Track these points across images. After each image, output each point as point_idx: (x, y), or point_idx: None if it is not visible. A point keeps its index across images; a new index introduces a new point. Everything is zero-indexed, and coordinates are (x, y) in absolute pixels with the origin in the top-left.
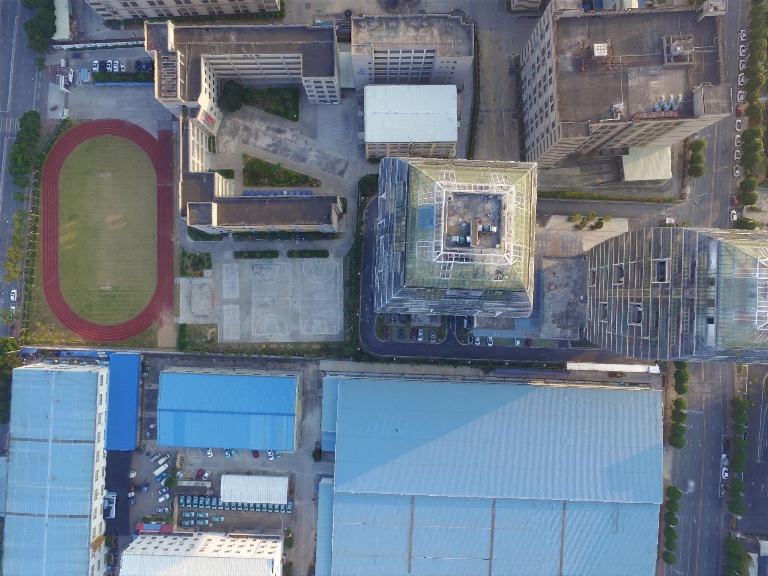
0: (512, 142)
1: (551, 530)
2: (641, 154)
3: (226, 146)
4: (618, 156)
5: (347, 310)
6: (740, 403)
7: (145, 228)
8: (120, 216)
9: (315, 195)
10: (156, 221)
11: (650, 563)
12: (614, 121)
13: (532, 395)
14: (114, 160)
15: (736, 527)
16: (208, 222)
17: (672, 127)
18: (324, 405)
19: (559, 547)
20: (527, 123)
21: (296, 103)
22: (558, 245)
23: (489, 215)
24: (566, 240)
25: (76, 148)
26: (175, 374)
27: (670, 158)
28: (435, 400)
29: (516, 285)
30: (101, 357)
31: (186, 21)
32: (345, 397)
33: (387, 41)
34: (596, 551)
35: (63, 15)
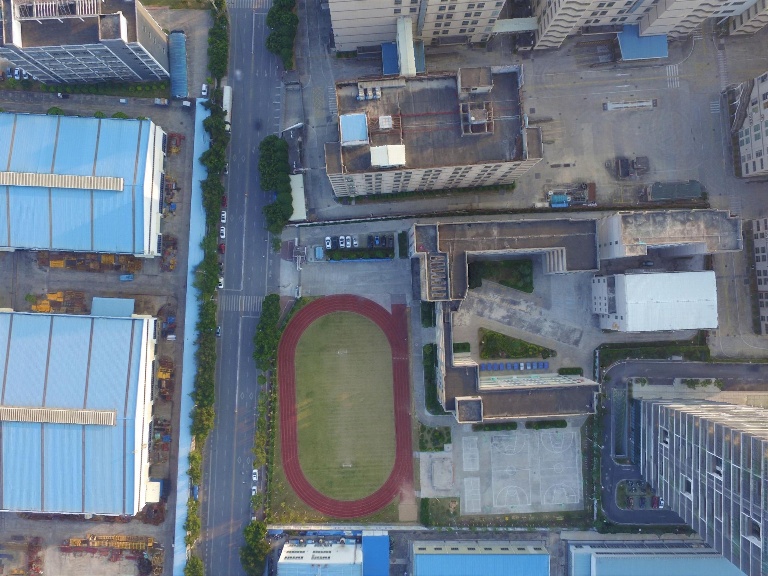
0: (744, 307)
1: None
2: None
3: (461, 319)
4: None
5: (586, 479)
6: None
7: (382, 403)
8: (357, 392)
9: (577, 384)
10: (393, 395)
11: None
12: None
13: None
14: (349, 336)
15: None
16: (477, 418)
17: None
18: None
19: None
20: (766, 294)
21: (530, 275)
22: None
23: None
24: None
25: (310, 325)
26: (429, 556)
27: None
28: (690, 575)
29: None
30: (346, 535)
31: (417, 195)
32: (602, 575)
33: (655, 236)
34: None
35: (299, 196)
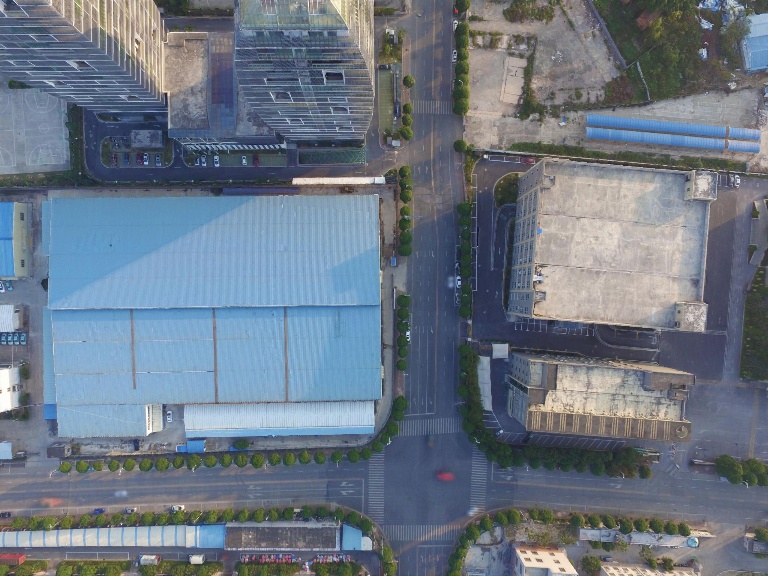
0: None
1: (273, 338)
2: None
3: None
4: None
5: None
6: (460, 206)
7: None
8: None
9: None
10: None
11: (375, 366)
12: None
13: (248, 205)
14: None
15: (472, 335)
16: None
17: None
18: (43, 229)
19: (283, 355)
20: None
21: None
22: None
23: None
24: None
25: None
26: None
27: None
28: (150, 214)
29: None
30: None
31: None
32: (58, 216)
33: None
34: (320, 357)
35: None
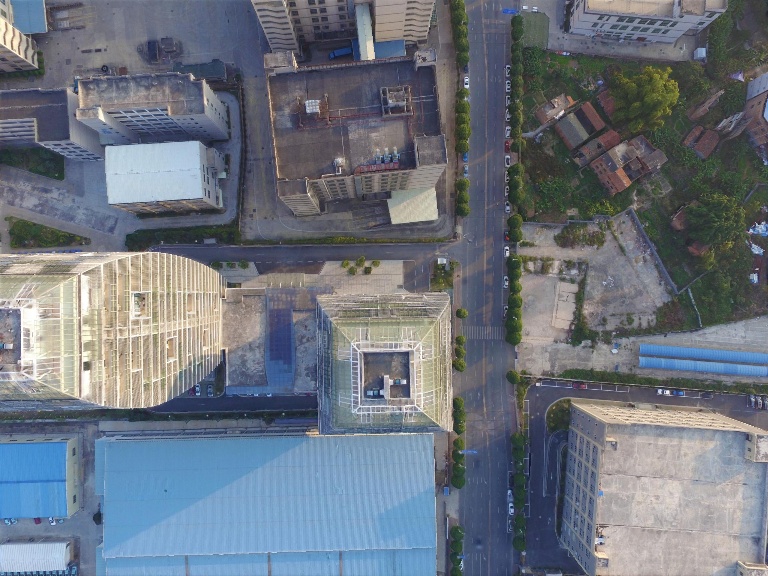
0: None
1: None
2: (406, 197)
3: None
4: (382, 200)
5: None
6: (515, 440)
7: None
8: None
9: None
10: None
11: None
12: (336, 175)
13: (303, 446)
14: None
15: (525, 562)
16: None
17: (405, 176)
18: (96, 468)
19: None
20: None
21: (60, 161)
22: (307, 298)
23: (10, 330)
24: (315, 292)
25: None
26: None
27: (435, 199)
28: (204, 458)
29: (60, 395)
30: None
31: None
32: (112, 460)
33: (118, 102)
34: None
35: None
